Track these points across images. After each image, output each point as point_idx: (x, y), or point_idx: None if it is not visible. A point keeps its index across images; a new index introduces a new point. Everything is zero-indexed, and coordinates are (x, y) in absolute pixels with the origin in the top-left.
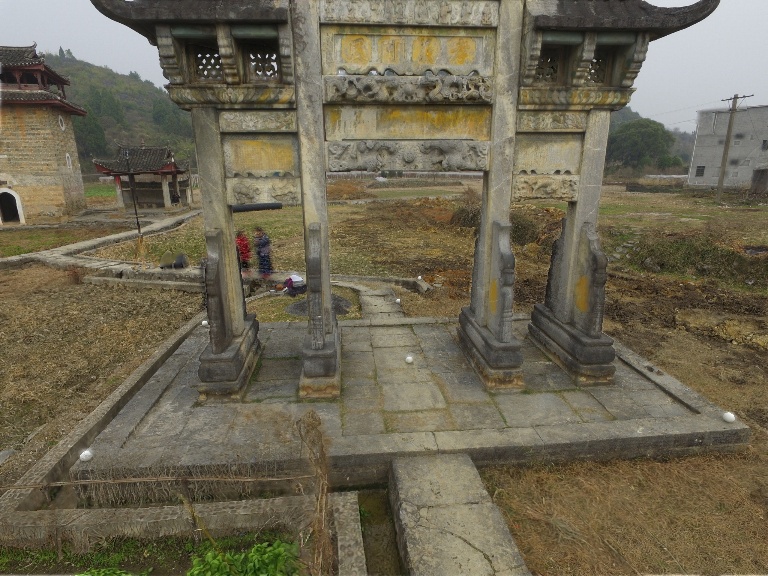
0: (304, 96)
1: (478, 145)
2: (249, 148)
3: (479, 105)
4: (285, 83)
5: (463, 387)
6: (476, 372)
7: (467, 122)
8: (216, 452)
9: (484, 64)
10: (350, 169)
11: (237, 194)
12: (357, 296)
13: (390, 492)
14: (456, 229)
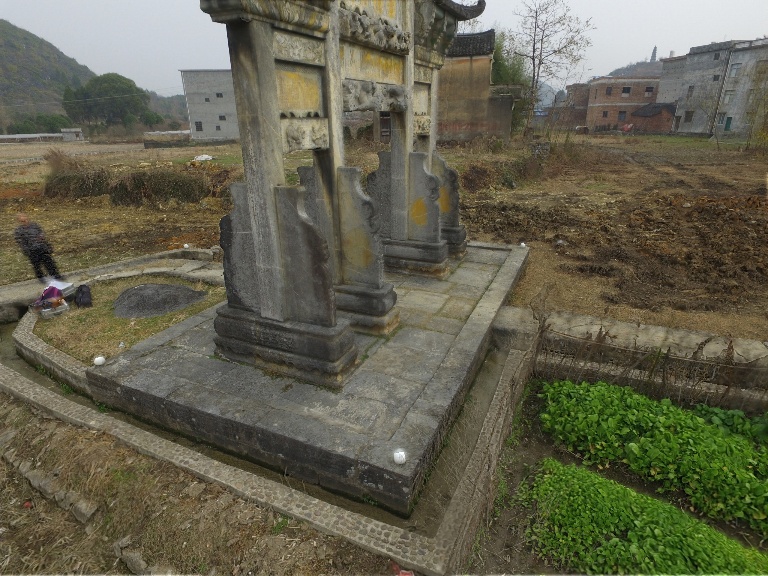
0: (330, 26)
1: (406, 90)
2: (290, 82)
3: (400, 56)
4: (326, 9)
5: (428, 285)
6: (416, 275)
7: (395, 70)
8: (440, 386)
9: (399, 21)
10: (359, 109)
11: (290, 139)
12: (172, 278)
13: (508, 344)
14: (72, 201)
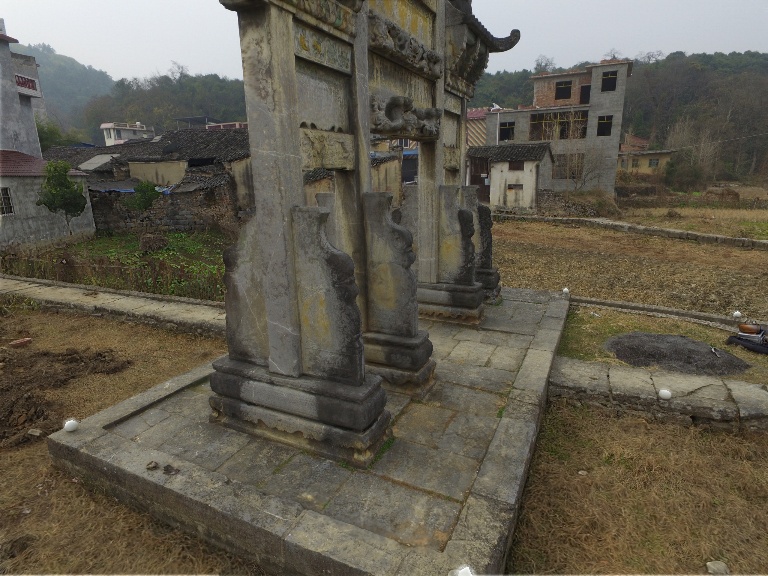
0: None
1: None
2: None
3: None
4: None
5: None
6: None
7: None
8: None
9: None
10: None
11: None
12: None
13: None
14: None
